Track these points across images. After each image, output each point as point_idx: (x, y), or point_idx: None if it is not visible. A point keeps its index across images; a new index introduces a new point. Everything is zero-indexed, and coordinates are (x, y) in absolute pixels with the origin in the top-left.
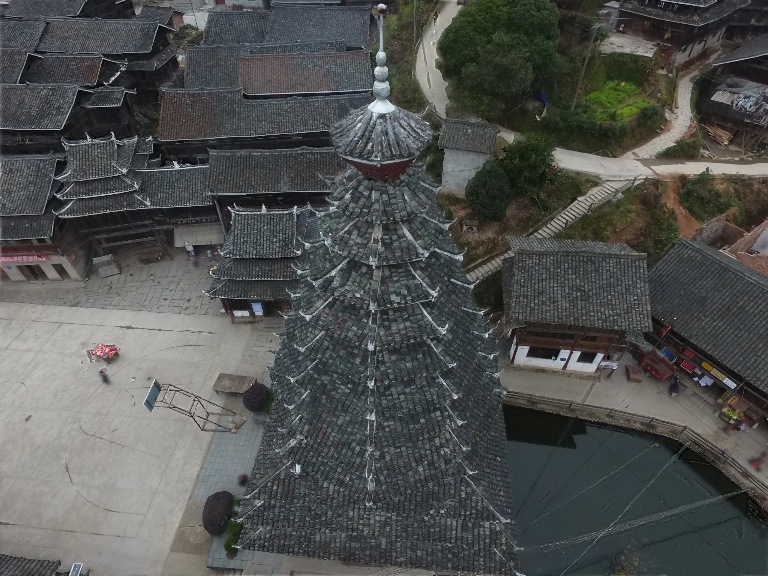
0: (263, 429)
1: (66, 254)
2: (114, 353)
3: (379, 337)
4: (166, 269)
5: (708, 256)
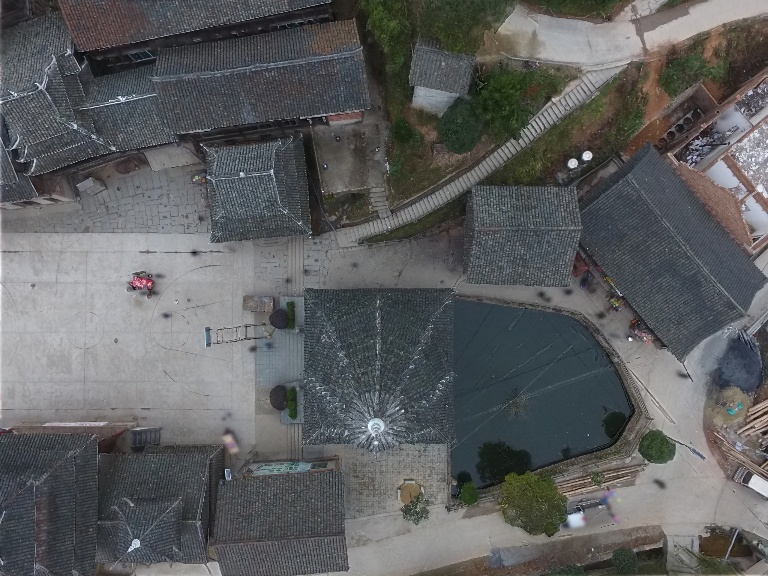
0: (289, 335)
1: (52, 191)
2: (151, 284)
3: None
4: (148, 179)
5: (642, 197)
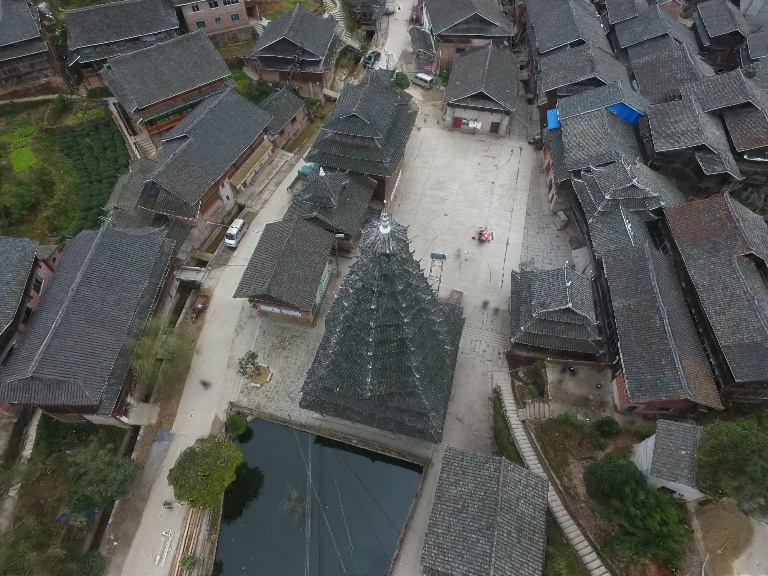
0: None
1: (559, 196)
2: (483, 239)
3: (348, 280)
4: (565, 255)
5: None
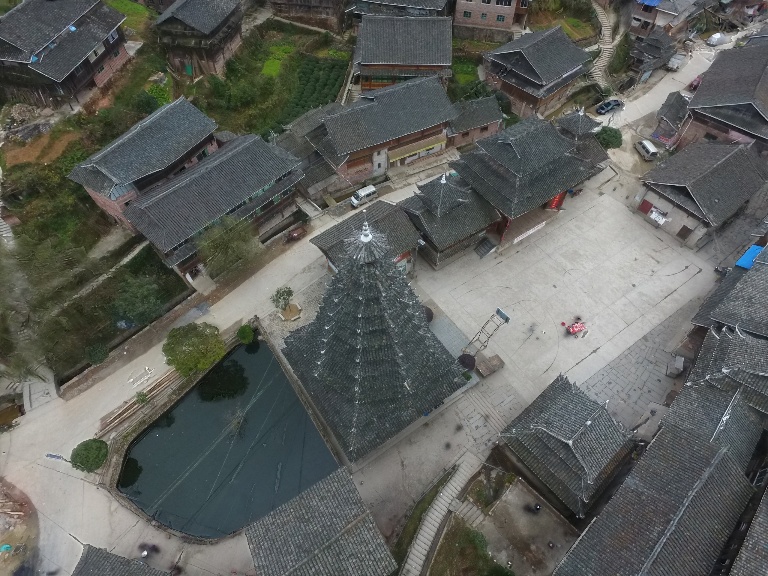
0: None
1: None
2: (570, 331)
3: None
4: None
5: None
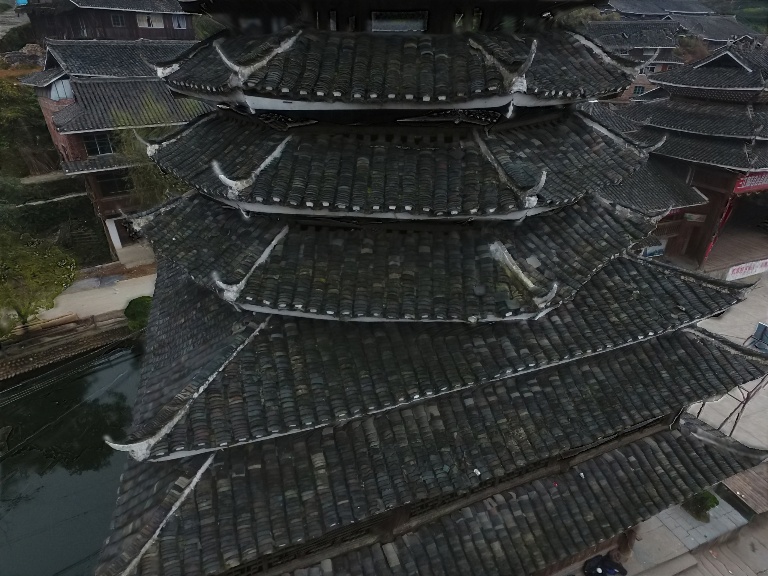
0: None
1: None
2: None
3: None
4: None
5: None
